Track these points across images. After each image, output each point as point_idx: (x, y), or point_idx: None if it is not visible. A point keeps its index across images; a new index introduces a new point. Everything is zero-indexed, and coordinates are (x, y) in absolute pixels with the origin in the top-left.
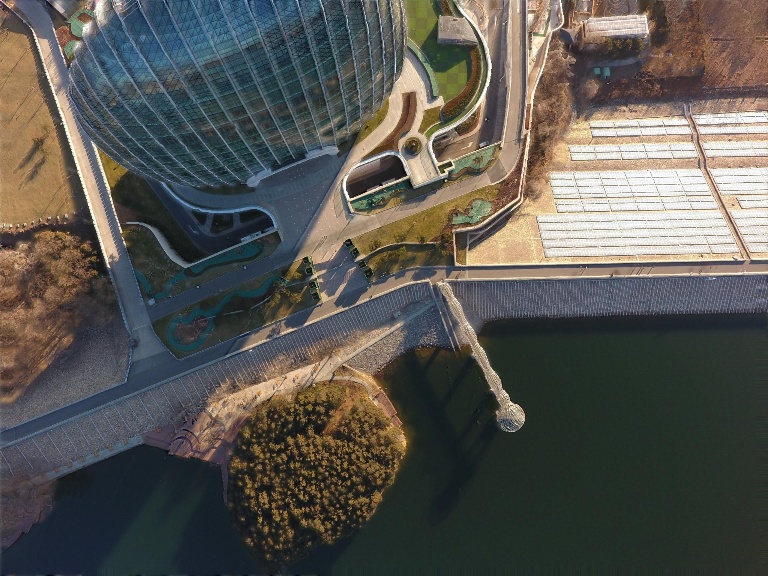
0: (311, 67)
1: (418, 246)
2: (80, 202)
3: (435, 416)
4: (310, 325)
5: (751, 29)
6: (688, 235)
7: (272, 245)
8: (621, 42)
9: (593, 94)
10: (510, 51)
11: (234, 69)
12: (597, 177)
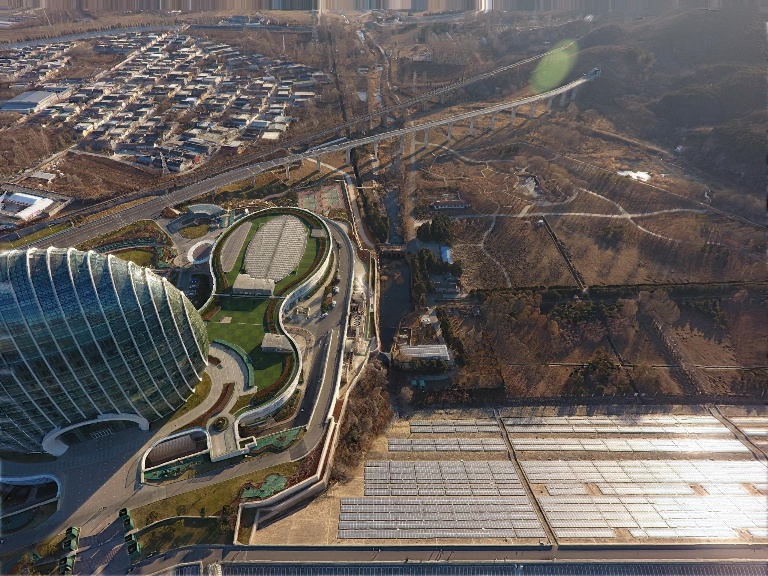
0: (84, 328)
1: (199, 520)
2: None
3: None
4: None
5: (536, 358)
6: (493, 519)
7: (45, 516)
8: (427, 361)
9: (409, 398)
10: (326, 360)
11: (12, 320)
12: (411, 466)
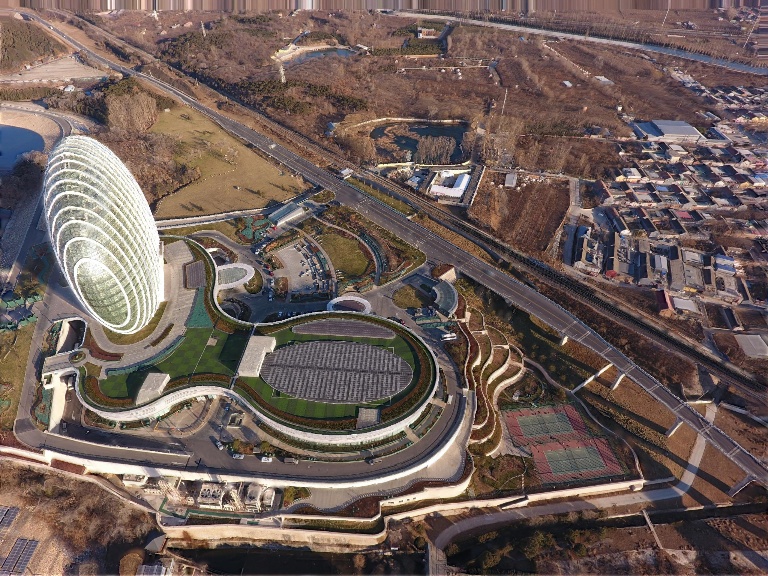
0: None
1: None
2: None
3: None
4: None
5: None
6: None
7: None
8: None
9: None
10: None
11: None
12: None
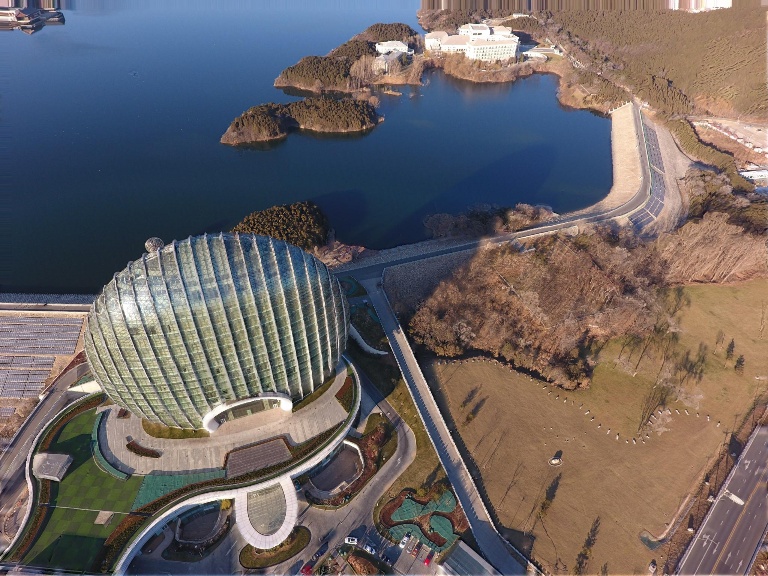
0: None
1: None
2: (428, 372)
3: None
4: None
5: None
6: None
7: None
8: None
9: None
10: (8, 471)
11: None
12: (5, 391)
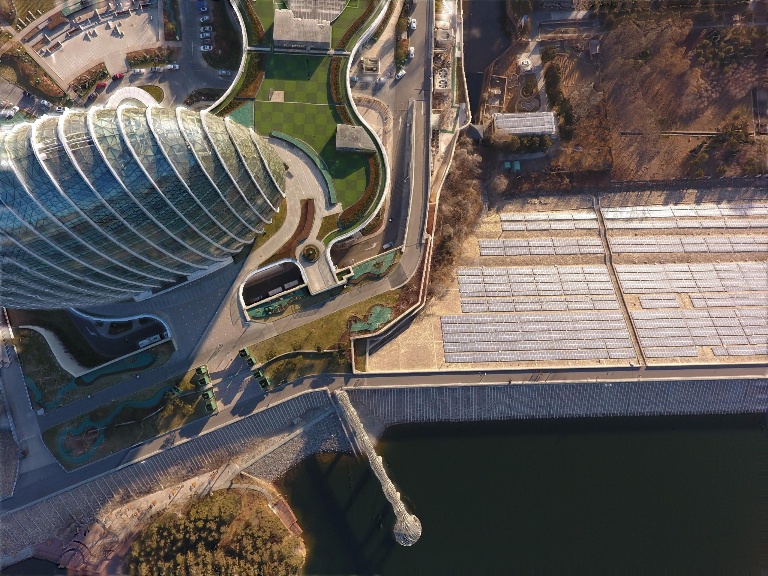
0: (156, 229)
1: (316, 354)
2: None
3: (336, 523)
4: (205, 435)
5: (657, 124)
6: (588, 338)
7: (166, 354)
8: (528, 139)
9: (503, 188)
10: (413, 154)
11: (65, 243)
12: (504, 273)
